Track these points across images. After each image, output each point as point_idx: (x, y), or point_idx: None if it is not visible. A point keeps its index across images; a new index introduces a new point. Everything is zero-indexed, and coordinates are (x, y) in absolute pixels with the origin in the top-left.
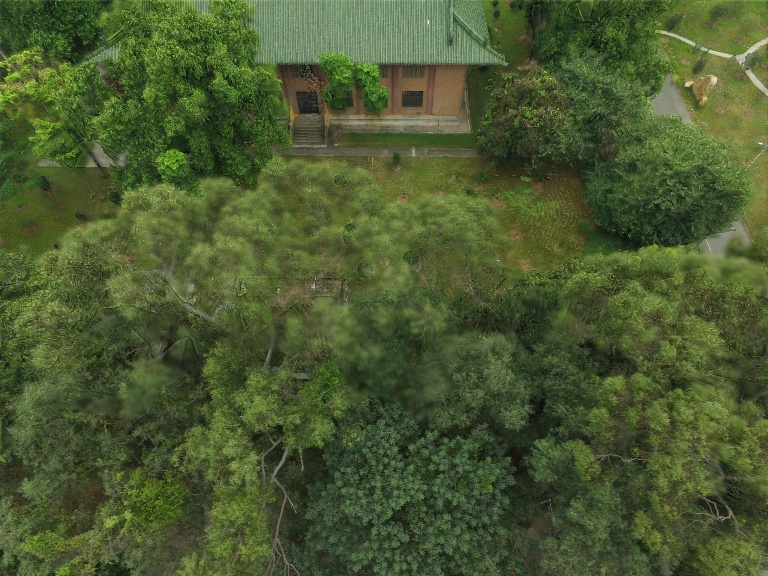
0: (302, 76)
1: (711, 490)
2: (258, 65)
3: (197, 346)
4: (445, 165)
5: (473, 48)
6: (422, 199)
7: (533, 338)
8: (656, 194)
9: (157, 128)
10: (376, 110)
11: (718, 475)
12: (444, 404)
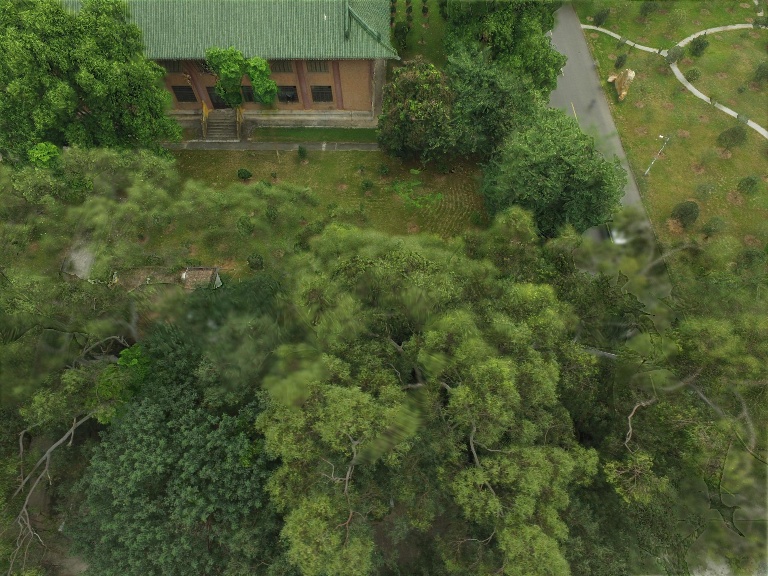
0: (206, 71)
1: (358, 455)
2: (158, 60)
3: (78, 335)
4: (353, 159)
5: (369, 43)
6: (325, 192)
7: (413, 327)
8: (527, 185)
9: (28, 121)
10: (288, 105)
11: (383, 442)
12: (315, 392)
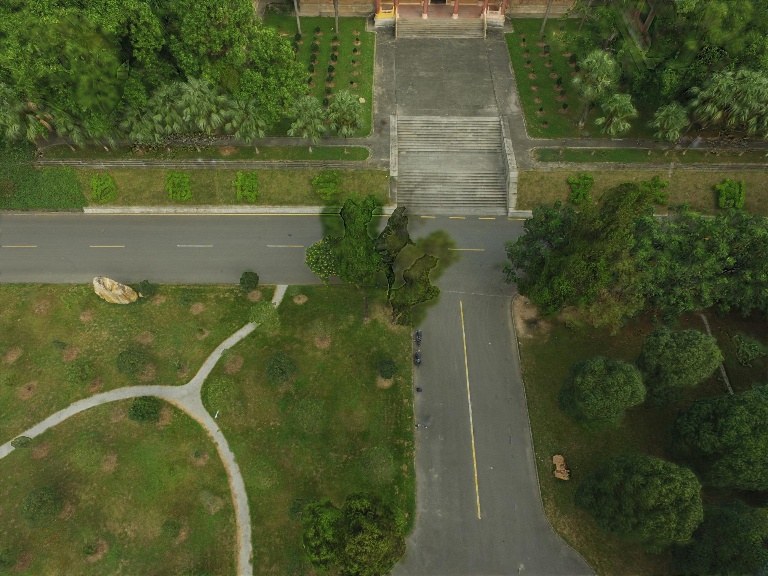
0: None
1: None
2: None
3: None
4: None
5: None
6: None
7: None
8: None
9: None
10: None
11: None
12: None
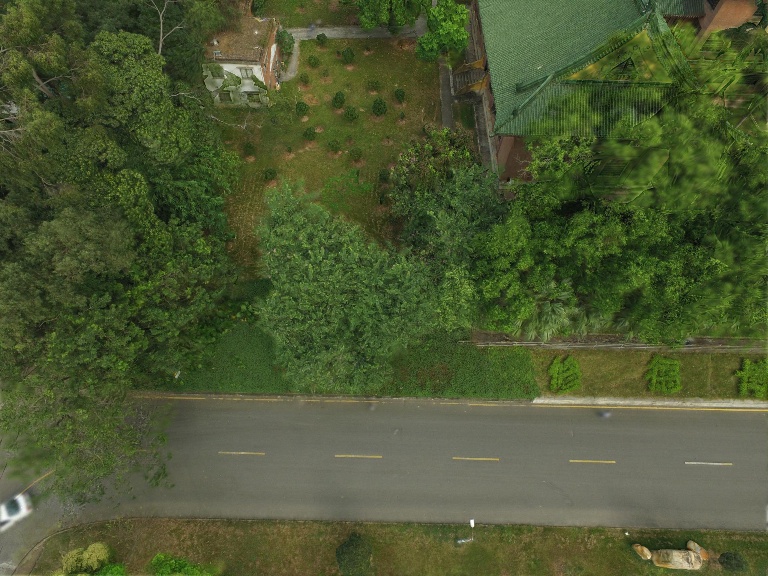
0: None
1: None
2: None
3: None
4: None
5: None
6: (387, 155)
7: None
8: None
9: None
10: None
11: None
12: None
